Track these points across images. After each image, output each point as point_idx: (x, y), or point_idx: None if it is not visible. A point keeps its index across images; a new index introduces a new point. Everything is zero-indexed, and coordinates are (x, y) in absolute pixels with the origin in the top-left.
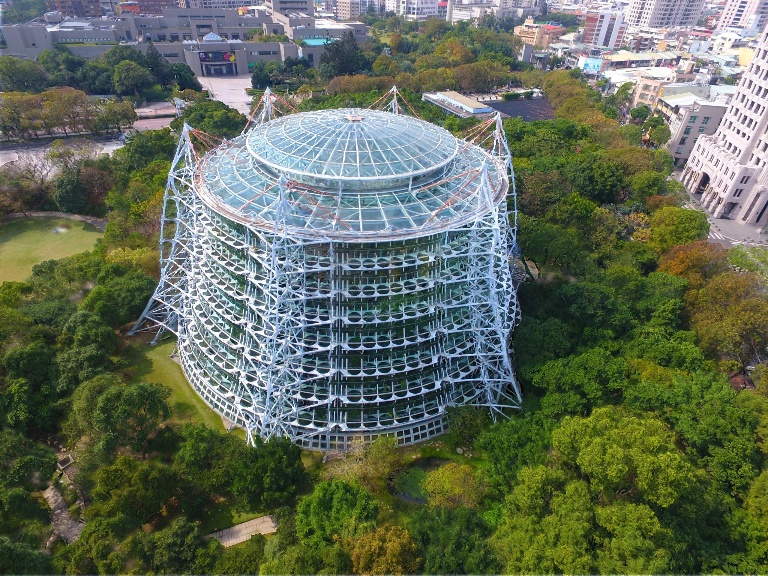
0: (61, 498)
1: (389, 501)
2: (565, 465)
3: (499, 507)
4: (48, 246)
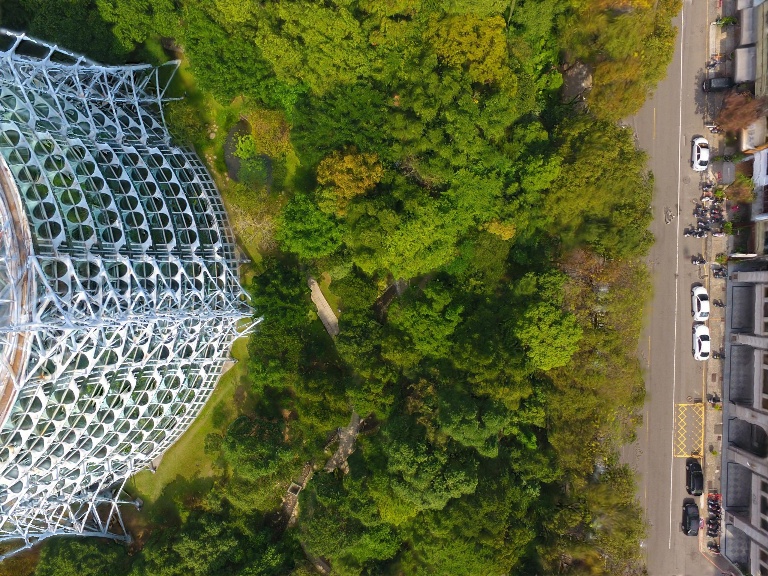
0: (324, 468)
1: (275, 196)
2: (239, 24)
3: (277, 93)
4: None
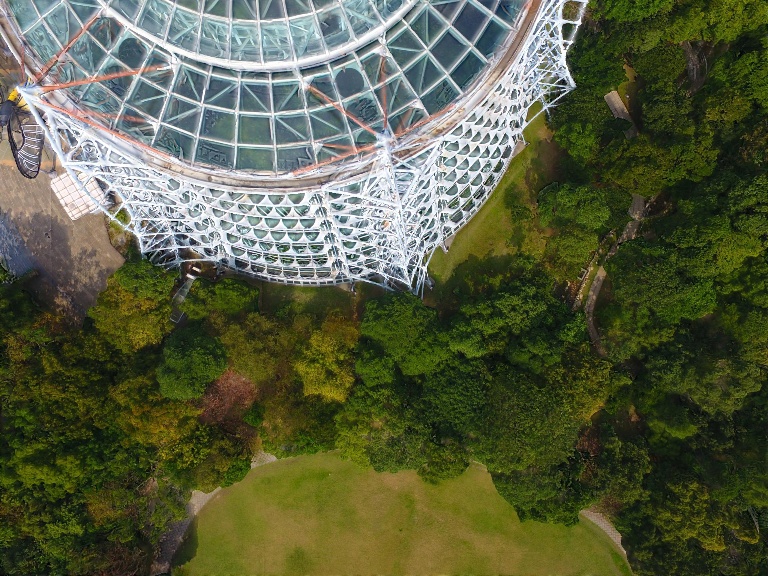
0: (609, 253)
1: None
2: None
3: None
4: (256, 568)
